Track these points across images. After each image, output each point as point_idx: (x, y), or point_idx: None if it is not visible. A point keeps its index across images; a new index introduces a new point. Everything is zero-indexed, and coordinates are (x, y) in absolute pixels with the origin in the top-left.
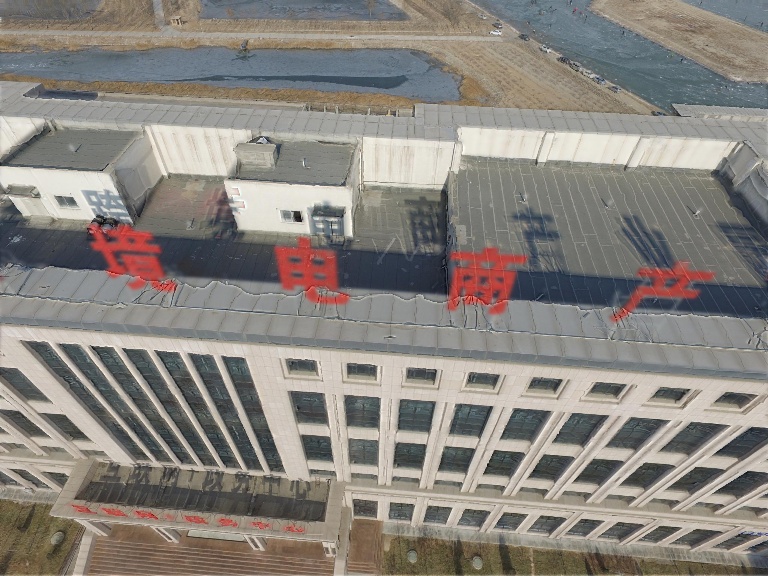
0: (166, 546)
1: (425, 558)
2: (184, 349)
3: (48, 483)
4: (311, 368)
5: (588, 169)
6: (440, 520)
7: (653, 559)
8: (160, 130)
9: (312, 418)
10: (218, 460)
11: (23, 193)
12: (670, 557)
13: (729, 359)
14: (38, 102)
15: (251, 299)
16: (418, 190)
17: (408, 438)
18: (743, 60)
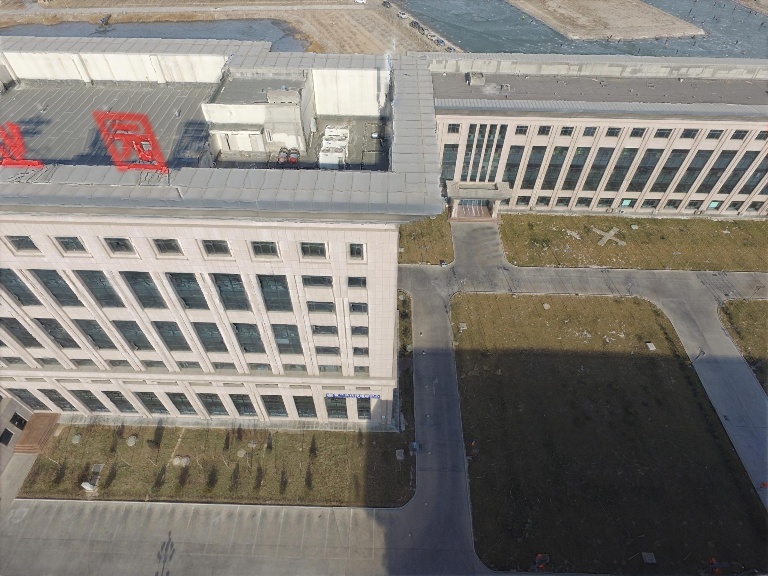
0: None
1: (87, 440)
2: None
3: None
4: None
5: (130, 87)
6: (106, 409)
7: (286, 430)
8: None
9: None
10: None
11: None
12: (300, 428)
13: None
14: None
15: None
16: None
17: None
18: (586, 20)
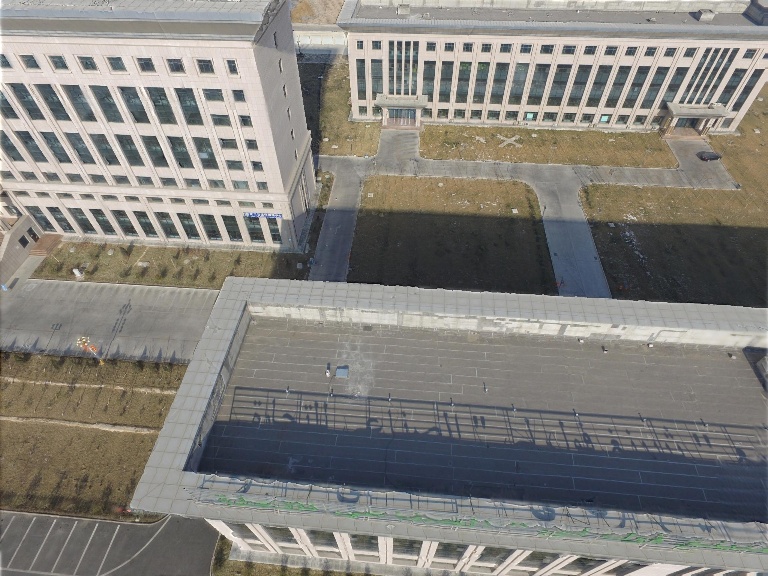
0: None
1: (80, 250)
2: None
3: None
4: None
5: None
6: (94, 231)
7: (221, 250)
8: None
9: None
10: None
11: None
12: (231, 249)
13: None
14: None
15: None
16: None
17: None
18: None
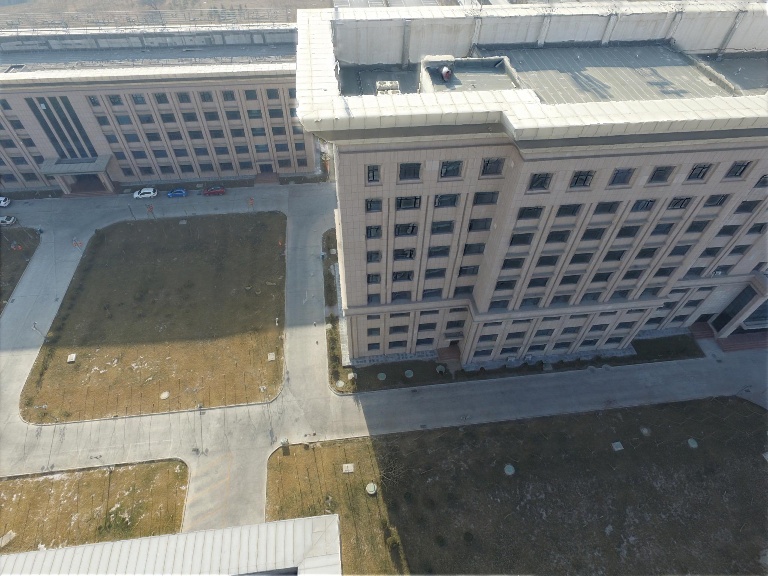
0: None
1: None
2: None
3: None
4: None
5: None
6: None
7: None
8: None
9: None
10: None
11: None
12: None
13: (566, 5)
14: None
15: (765, 7)
16: None
17: None
18: None
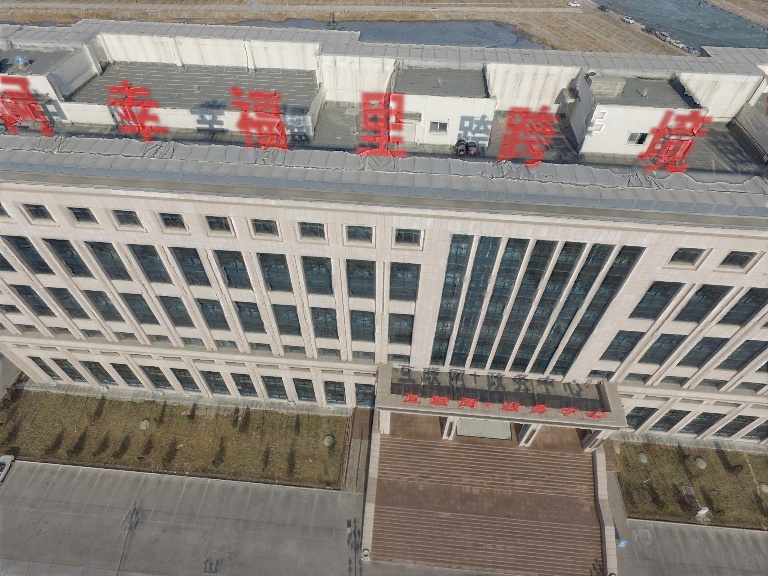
0: (442, 442)
1: (653, 459)
2: (598, 239)
3: (318, 394)
4: (688, 258)
5: None
6: (663, 428)
7: None
8: (496, 68)
9: (639, 313)
10: (510, 362)
11: (413, 118)
12: None
13: None
14: (378, 46)
15: None
16: (705, 123)
17: (717, 331)
18: None
